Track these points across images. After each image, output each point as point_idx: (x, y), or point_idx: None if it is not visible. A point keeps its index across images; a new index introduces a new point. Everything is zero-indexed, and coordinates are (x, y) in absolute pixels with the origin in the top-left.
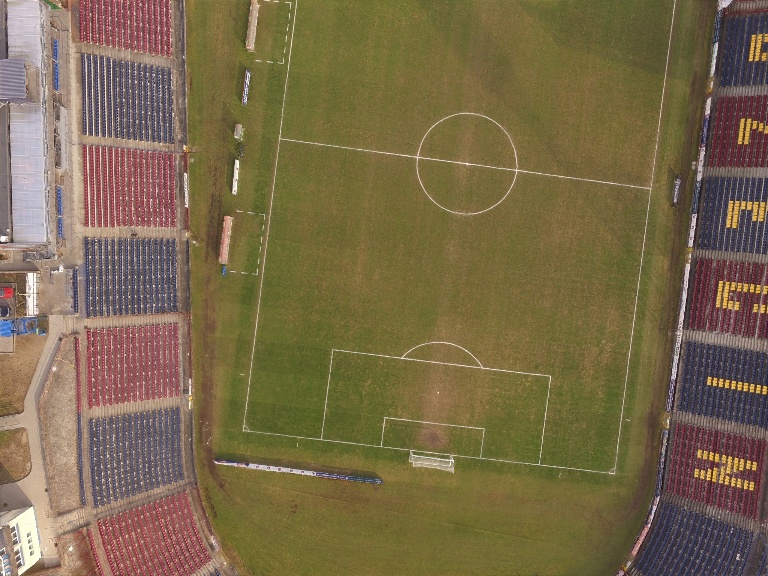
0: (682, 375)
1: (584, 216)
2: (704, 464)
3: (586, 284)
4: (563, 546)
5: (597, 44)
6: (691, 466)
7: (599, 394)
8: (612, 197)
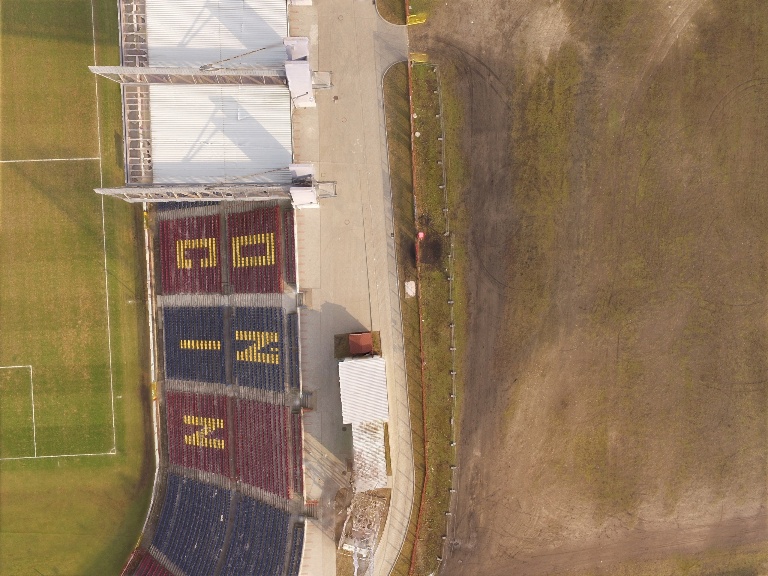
0: (165, 342)
1: (35, 198)
2: (190, 429)
3: (50, 267)
4: (76, 534)
5: (16, 20)
6: (182, 433)
7: (85, 376)
8: (61, 174)
